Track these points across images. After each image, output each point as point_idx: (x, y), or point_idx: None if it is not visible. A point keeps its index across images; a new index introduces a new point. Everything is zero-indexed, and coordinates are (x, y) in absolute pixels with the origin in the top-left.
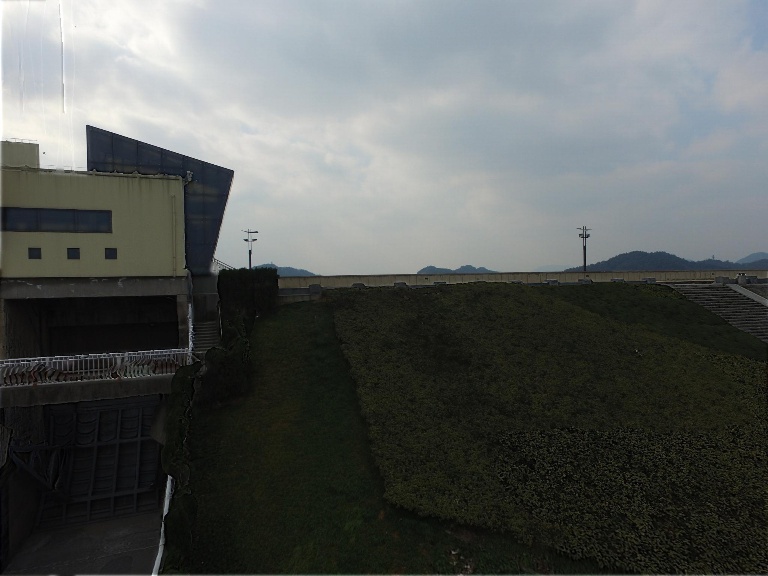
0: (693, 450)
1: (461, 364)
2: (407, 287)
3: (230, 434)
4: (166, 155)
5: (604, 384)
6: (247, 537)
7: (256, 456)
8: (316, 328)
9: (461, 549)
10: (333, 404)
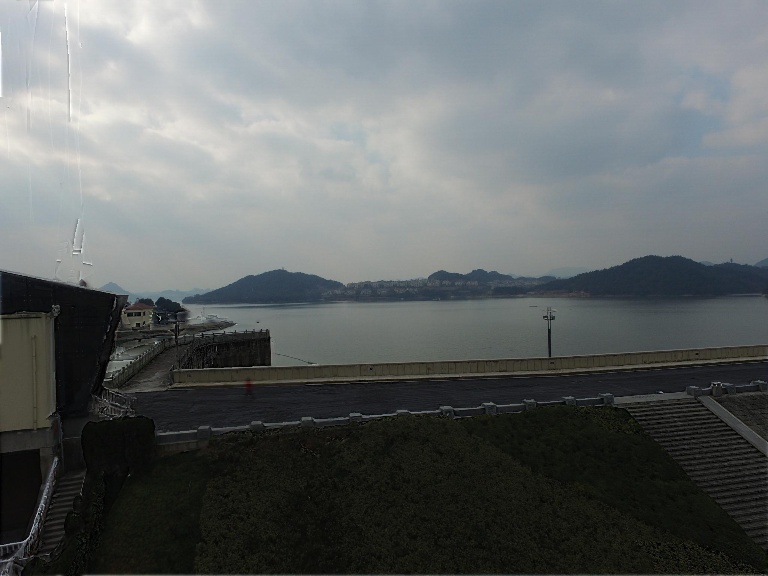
0: None
1: (336, 575)
2: (312, 427)
3: None
4: (33, 284)
5: None
6: None
7: None
8: (184, 504)
9: None
10: None
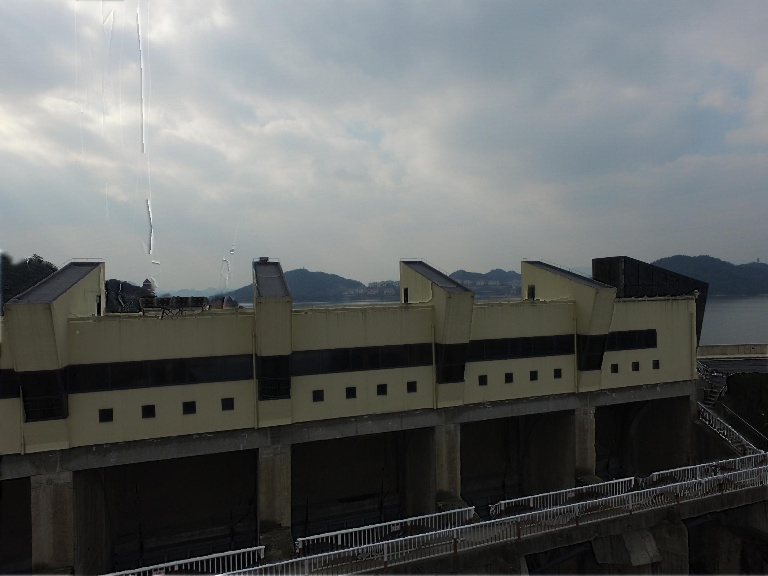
0: None
1: None
2: None
3: None
4: (668, 275)
5: None
6: None
7: None
8: None
9: None
10: None
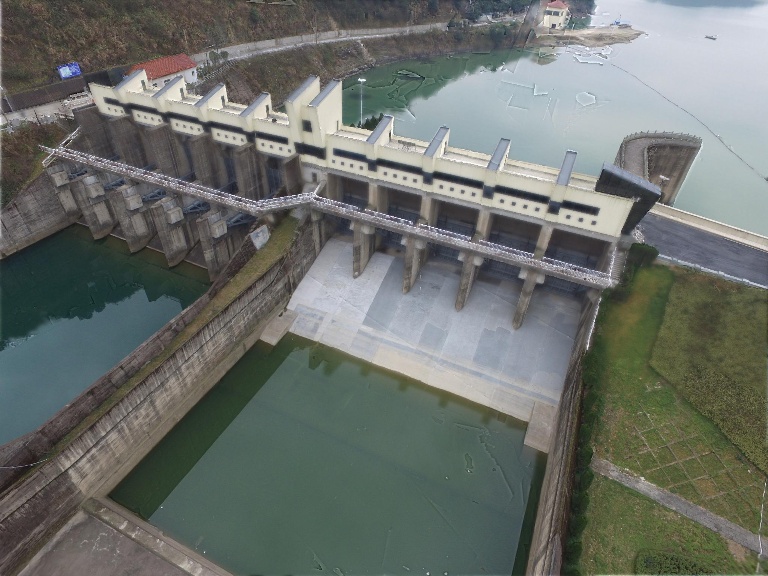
0: (767, 406)
1: (711, 333)
2: (723, 278)
3: (614, 315)
4: (632, 184)
5: (765, 371)
6: (609, 348)
7: (619, 327)
8: (662, 286)
9: (660, 383)
10: (651, 324)
